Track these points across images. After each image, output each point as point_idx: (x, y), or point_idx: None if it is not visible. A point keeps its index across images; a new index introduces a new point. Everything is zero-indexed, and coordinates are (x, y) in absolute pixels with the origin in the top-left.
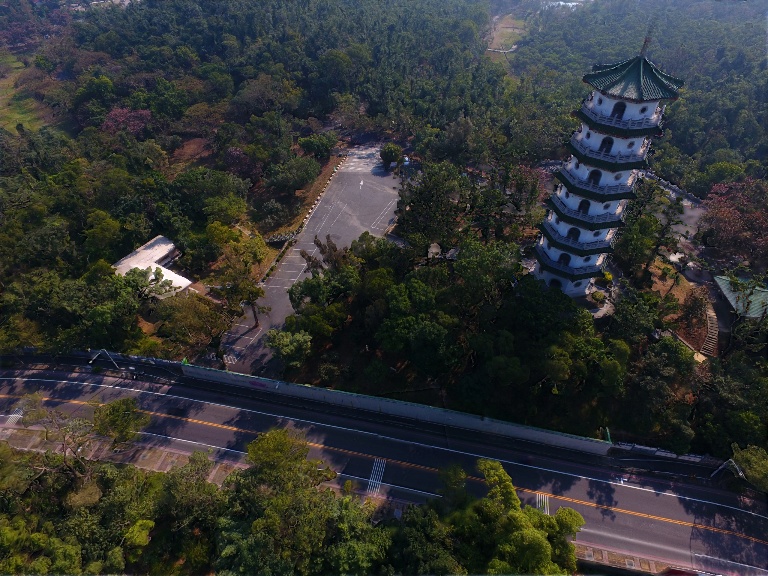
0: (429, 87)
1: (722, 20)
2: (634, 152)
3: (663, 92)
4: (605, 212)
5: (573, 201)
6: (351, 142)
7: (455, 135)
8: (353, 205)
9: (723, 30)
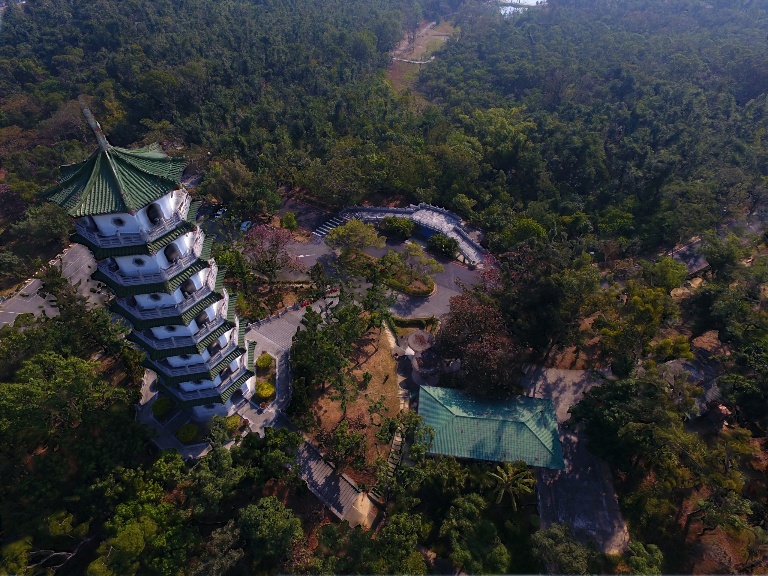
0: (249, 114)
1: (655, 32)
2: (151, 270)
3: (117, 203)
4: (170, 336)
5: None
6: None
7: None
8: None
9: (636, 46)
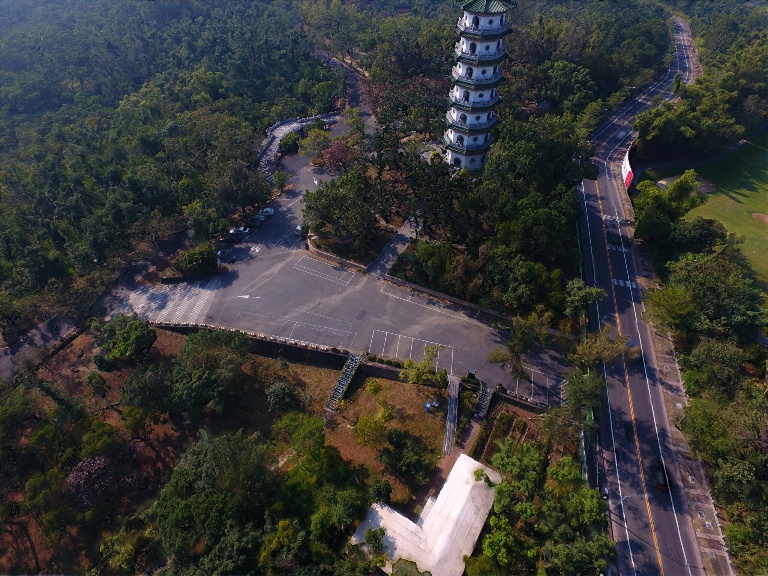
0: None
1: None
2: None
3: None
4: None
5: (488, 95)
6: (84, 328)
7: (235, 185)
8: (298, 302)
9: (57, 34)
